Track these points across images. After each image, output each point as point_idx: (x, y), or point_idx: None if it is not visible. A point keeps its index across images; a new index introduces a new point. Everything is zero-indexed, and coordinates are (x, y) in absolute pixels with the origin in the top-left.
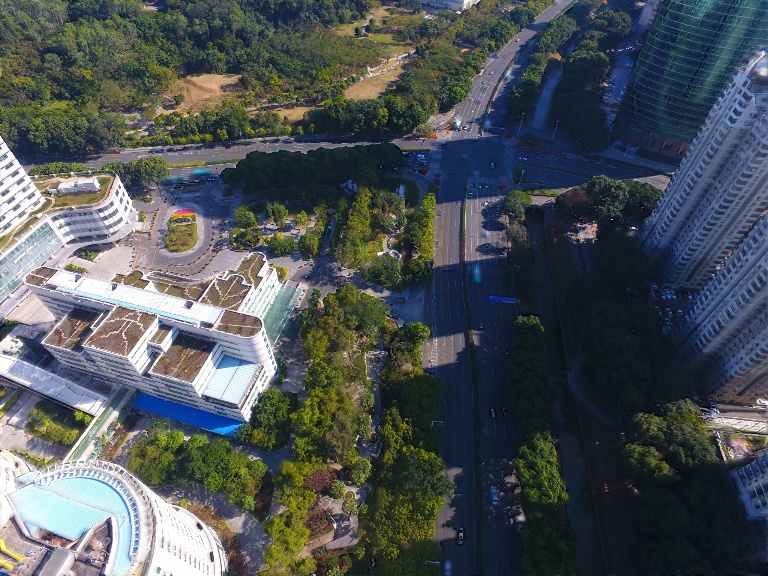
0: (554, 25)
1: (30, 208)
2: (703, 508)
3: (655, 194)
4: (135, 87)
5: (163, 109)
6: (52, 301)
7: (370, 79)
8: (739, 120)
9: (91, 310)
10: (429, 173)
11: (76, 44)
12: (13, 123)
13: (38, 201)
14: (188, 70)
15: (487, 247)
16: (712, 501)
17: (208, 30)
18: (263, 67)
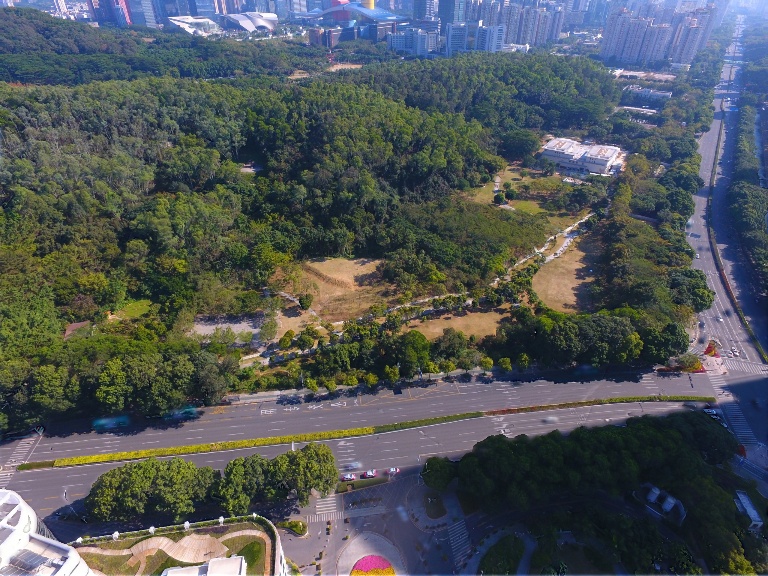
0: (748, 195)
1: None
2: None
3: None
4: (242, 282)
5: (283, 315)
6: None
7: (546, 265)
8: None
9: None
10: (750, 453)
11: (171, 228)
12: (75, 370)
13: None
14: (303, 251)
15: None
16: None
17: (331, 202)
18: (412, 253)
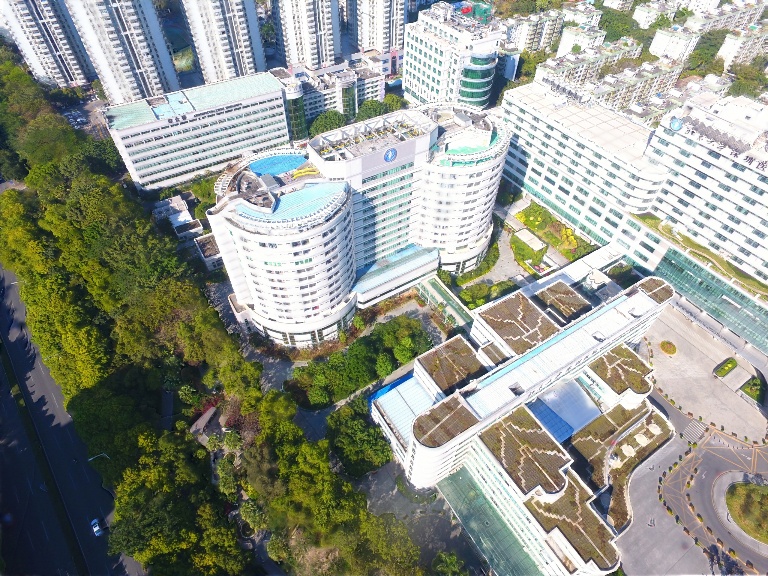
0: None
1: None
2: None
3: None
4: None
5: None
6: None
7: None
8: None
9: None
10: None
11: None
12: None
13: None
14: None
15: None
16: None
17: None
18: None
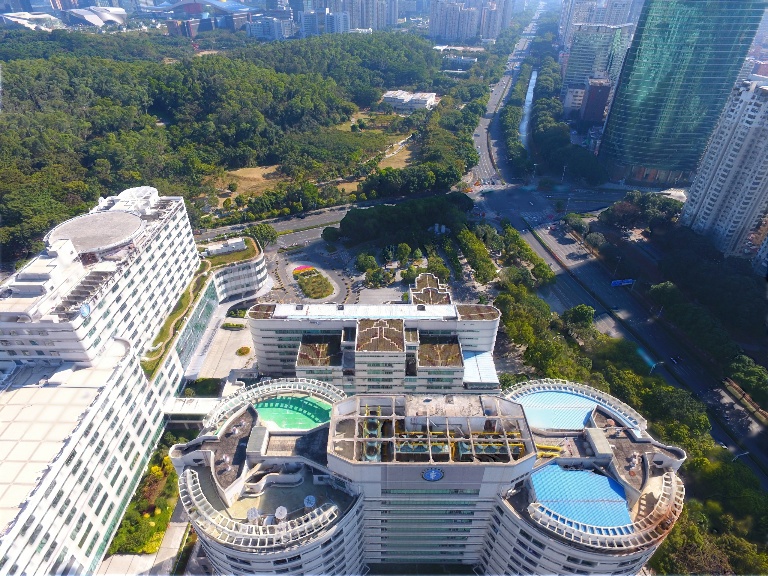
0: (509, 111)
1: (194, 268)
2: None
3: (671, 200)
4: (184, 182)
5: (219, 197)
6: (275, 335)
7: (387, 159)
8: (754, 122)
9: (321, 334)
10: (487, 215)
11: (125, 149)
12: None
13: (197, 262)
14: None
15: (573, 255)
16: None
17: (235, 133)
18: (299, 156)
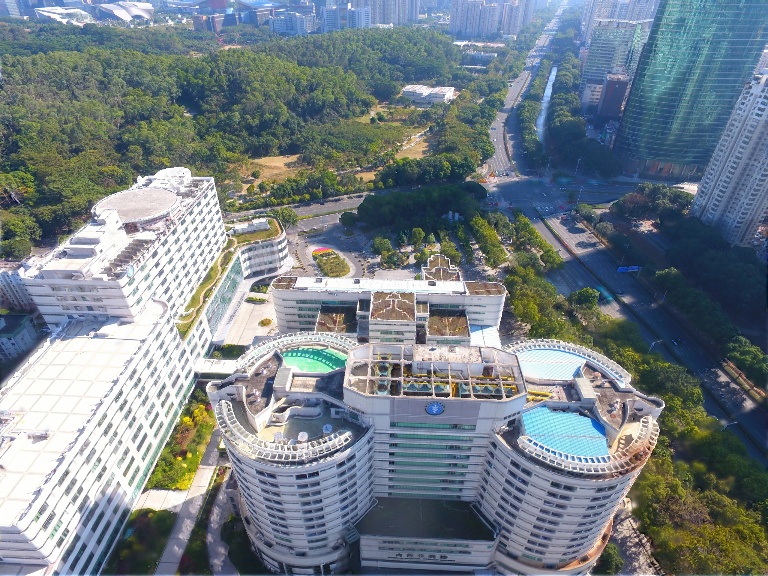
0: (526, 105)
1: (222, 245)
2: None
3: (682, 193)
4: (210, 169)
5: None
6: (296, 305)
7: (405, 150)
8: (764, 114)
9: (338, 305)
10: (500, 204)
11: (156, 136)
12: None
13: (225, 239)
14: None
15: (583, 244)
16: None
17: (258, 123)
18: (319, 146)
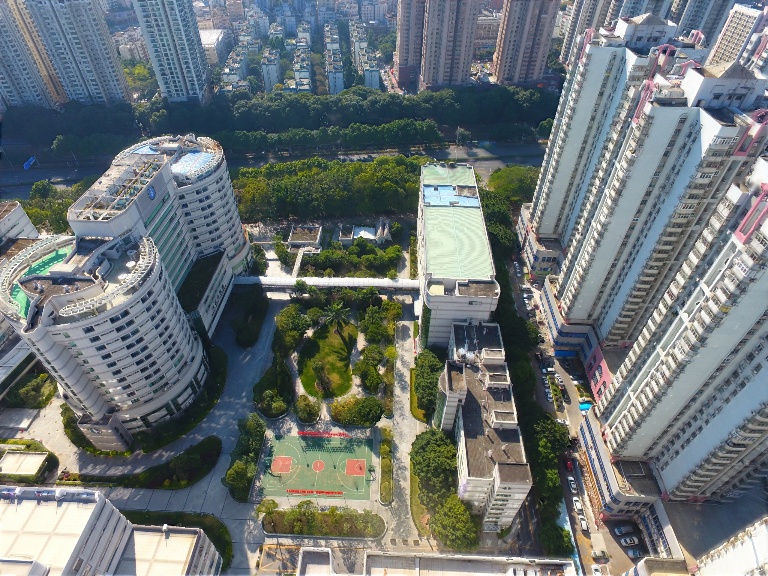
0: None
1: None
2: (182, 105)
3: None
4: None
5: None
6: None
7: None
8: None
9: None
10: None
11: None
12: None
13: None
14: None
15: None
16: (180, 103)
17: None
18: None
